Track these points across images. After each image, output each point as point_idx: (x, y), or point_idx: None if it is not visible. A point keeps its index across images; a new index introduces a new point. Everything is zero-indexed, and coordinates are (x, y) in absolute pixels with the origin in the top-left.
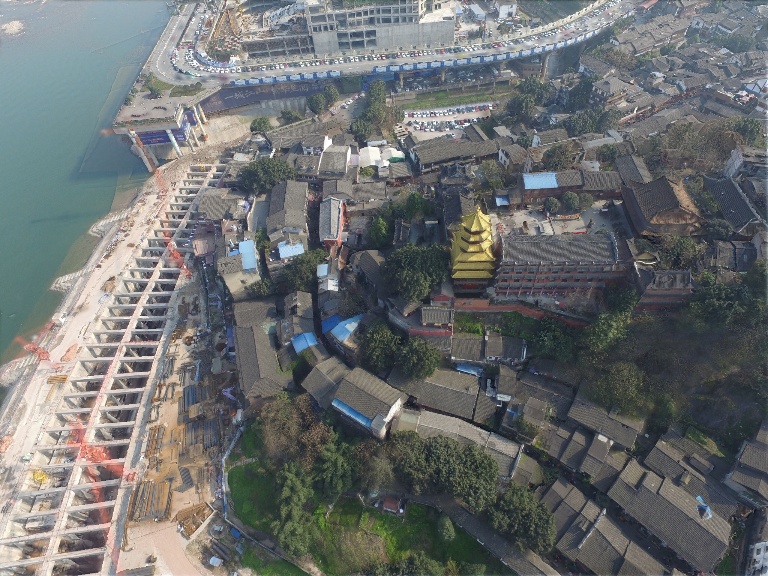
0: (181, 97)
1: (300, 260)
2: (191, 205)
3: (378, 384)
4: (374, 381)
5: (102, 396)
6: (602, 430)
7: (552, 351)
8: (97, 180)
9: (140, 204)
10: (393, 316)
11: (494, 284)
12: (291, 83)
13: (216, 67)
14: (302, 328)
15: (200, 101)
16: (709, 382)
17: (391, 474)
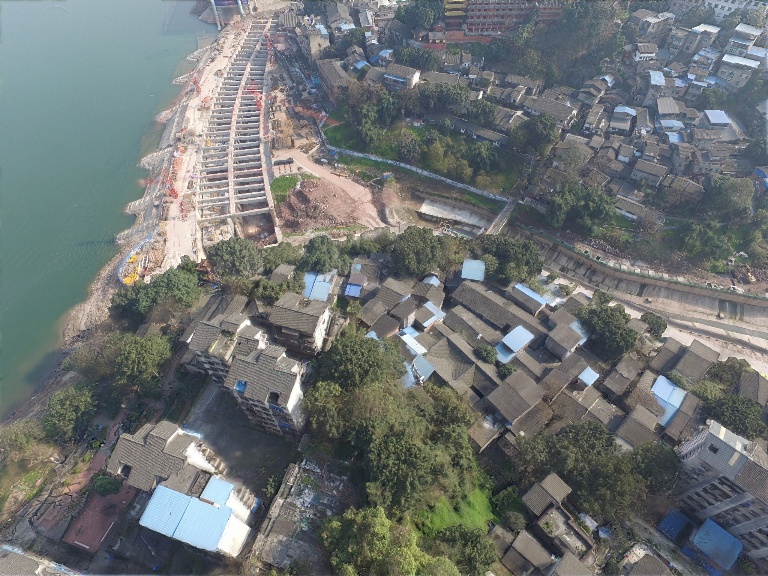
0: None
1: (355, 29)
2: (260, 39)
3: None
4: None
5: (235, 114)
6: (521, 83)
7: (497, 52)
8: (181, 34)
9: (224, 39)
10: (413, 41)
11: (466, 21)
12: None
13: None
14: (360, 58)
15: None
16: (572, 59)
17: None
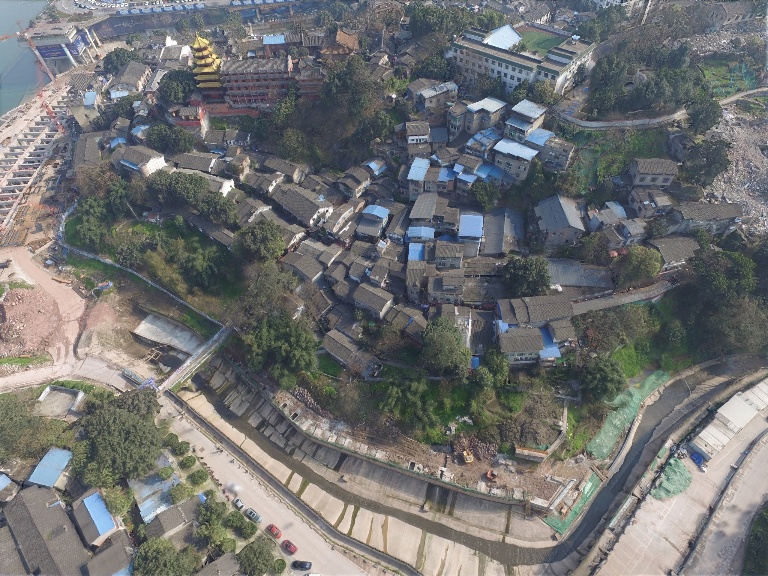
0: (76, 22)
1: (123, 98)
2: None
3: (150, 151)
4: (148, 150)
5: None
6: (279, 169)
7: (259, 130)
8: (11, 88)
9: (38, 96)
10: (167, 117)
11: (226, 92)
12: (167, 14)
13: (109, 3)
14: (117, 135)
15: (92, 26)
16: (342, 139)
17: (144, 188)
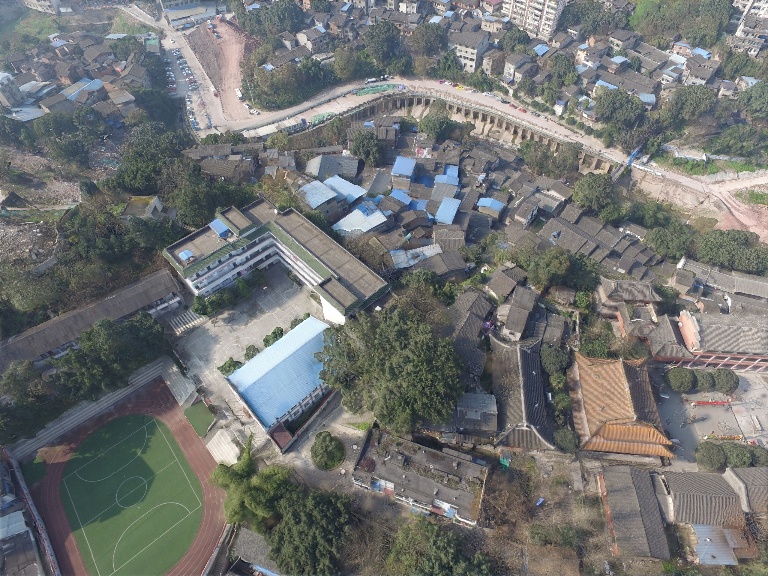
0: None
1: None
2: None
3: None
4: None
5: None
6: None
7: None
8: None
9: None
10: None
11: None
12: None
13: None
14: None
15: None
16: None
17: None
